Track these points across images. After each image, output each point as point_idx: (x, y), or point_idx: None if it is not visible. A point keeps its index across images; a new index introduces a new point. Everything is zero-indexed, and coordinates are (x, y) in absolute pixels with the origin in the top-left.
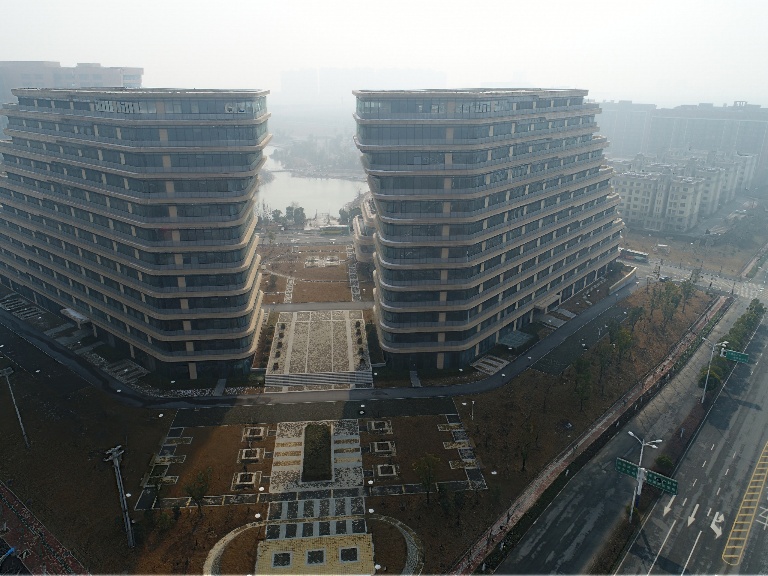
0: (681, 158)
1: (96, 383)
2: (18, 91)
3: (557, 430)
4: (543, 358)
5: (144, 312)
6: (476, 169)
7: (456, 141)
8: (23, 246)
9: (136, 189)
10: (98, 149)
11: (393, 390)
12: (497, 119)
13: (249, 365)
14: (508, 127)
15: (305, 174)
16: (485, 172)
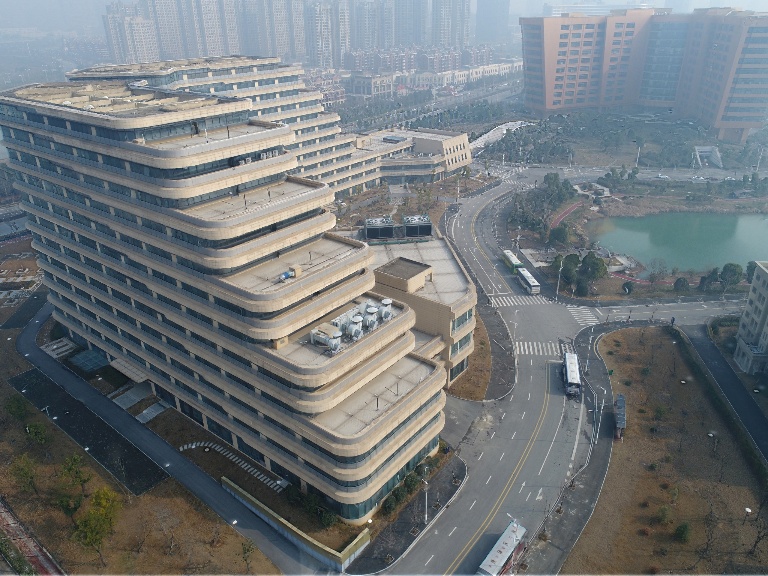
0: None
1: None
2: None
3: None
4: (47, 378)
5: None
6: None
7: None
8: None
9: None
10: None
11: None
12: (5, 123)
13: None
14: (27, 135)
15: None
16: None
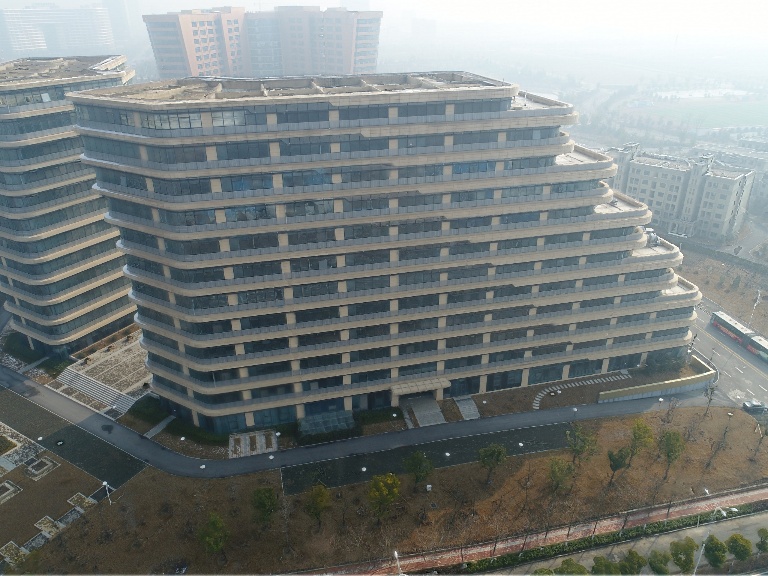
0: None
1: None
2: None
3: (158, 569)
4: (319, 463)
5: None
6: (180, 203)
7: (151, 164)
8: None
9: None
10: None
11: (122, 431)
12: (212, 138)
13: (69, 352)
14: (260, 148)
15: None
16: (199, 208)
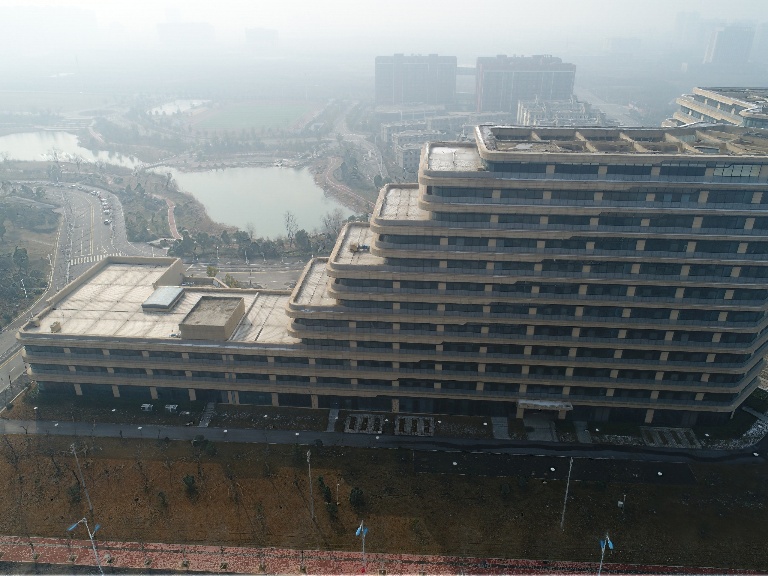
0: (558, 110)
1: (685, 460)
2: (517, 156)
3: None
4: None
5: (716, 372)
6: None
7: None
8: (394, 347)
9: (761, 252)
10: (698, 216)
11: None
12: None
13: None
14: None
15: (194, 166)
16: None
